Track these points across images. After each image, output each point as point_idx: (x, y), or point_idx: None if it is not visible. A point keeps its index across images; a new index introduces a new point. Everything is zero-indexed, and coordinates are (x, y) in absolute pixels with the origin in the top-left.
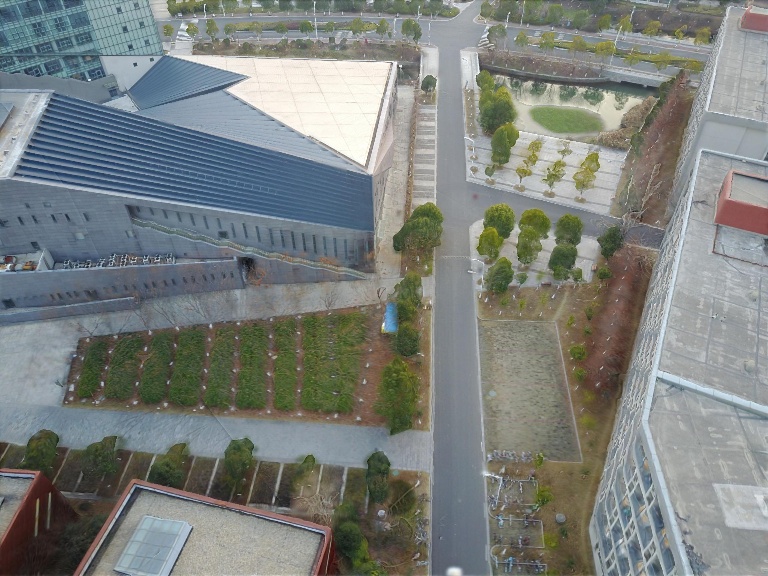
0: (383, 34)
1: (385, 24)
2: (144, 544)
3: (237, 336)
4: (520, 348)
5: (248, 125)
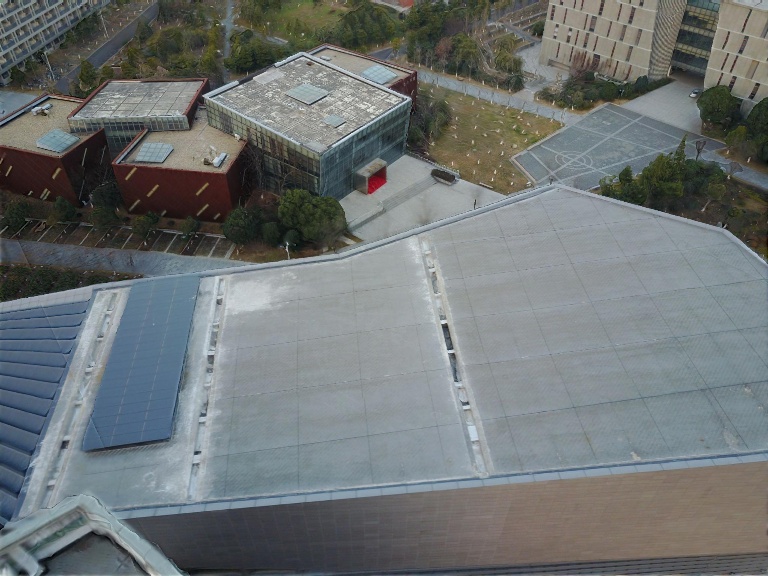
0: None
1: None
2: (62, 141)
3: None
4: None
5: None
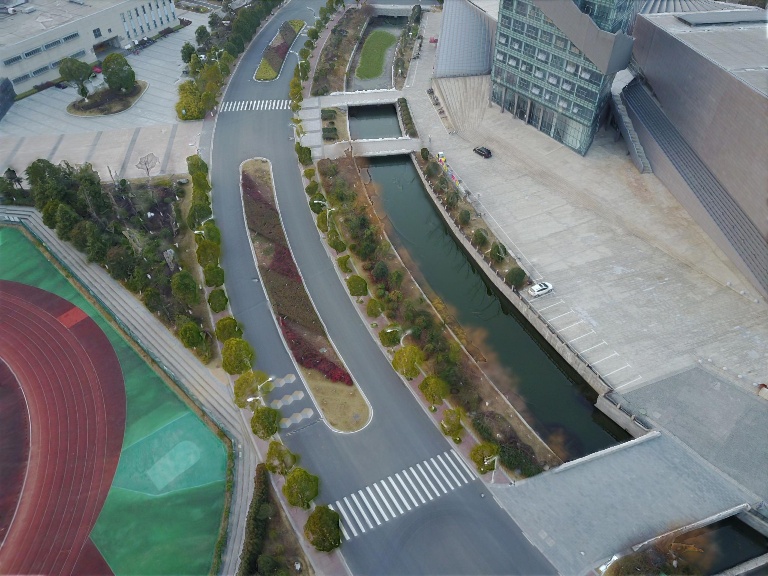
0: (336, 11)
1: (333, 2)
2: None
3: None
4: None
5: None
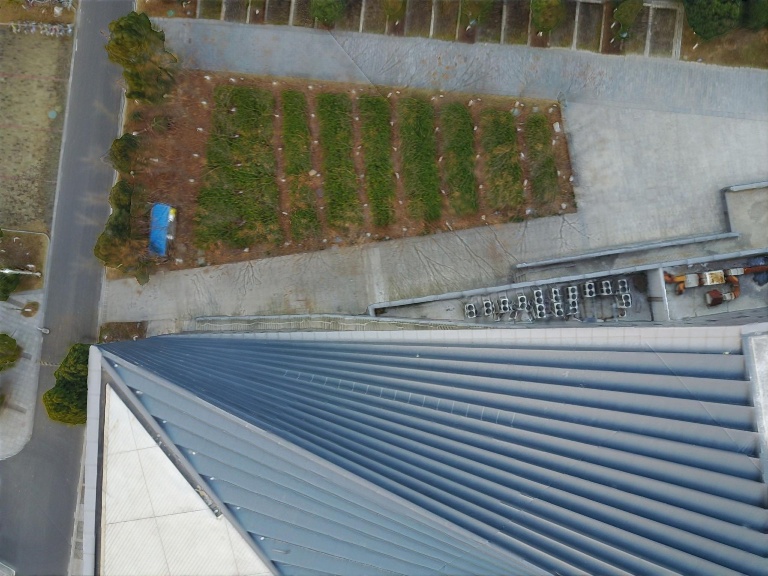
0: None
1: None
2: None
3: (365, 206)
4: (6, 182)
5: (348, 574)
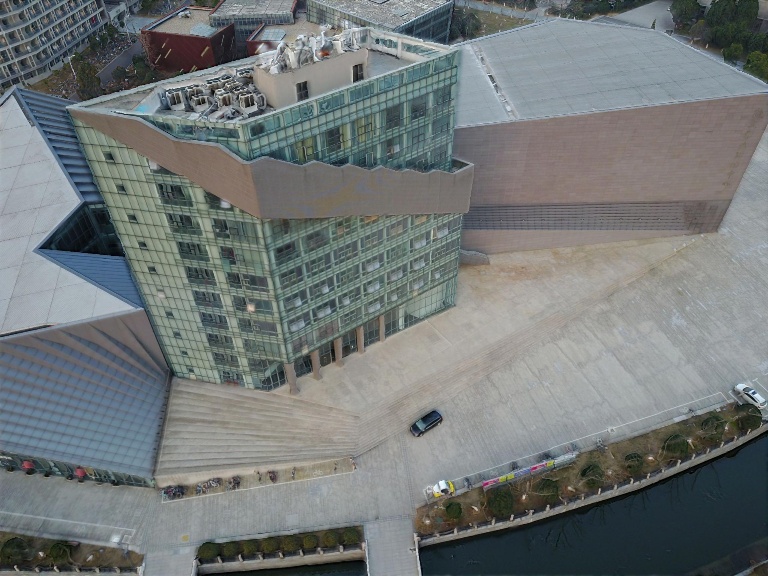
0: None
1: None
2: (206, 30)
3: None
4: None
5: None
